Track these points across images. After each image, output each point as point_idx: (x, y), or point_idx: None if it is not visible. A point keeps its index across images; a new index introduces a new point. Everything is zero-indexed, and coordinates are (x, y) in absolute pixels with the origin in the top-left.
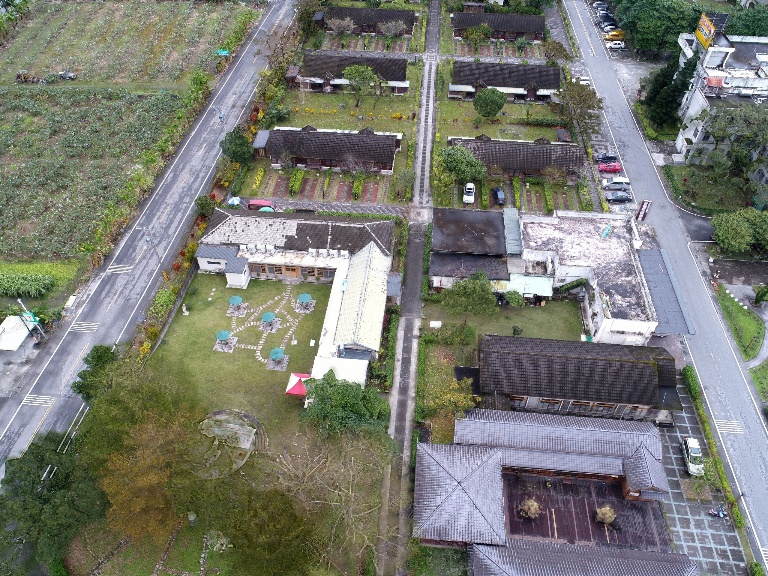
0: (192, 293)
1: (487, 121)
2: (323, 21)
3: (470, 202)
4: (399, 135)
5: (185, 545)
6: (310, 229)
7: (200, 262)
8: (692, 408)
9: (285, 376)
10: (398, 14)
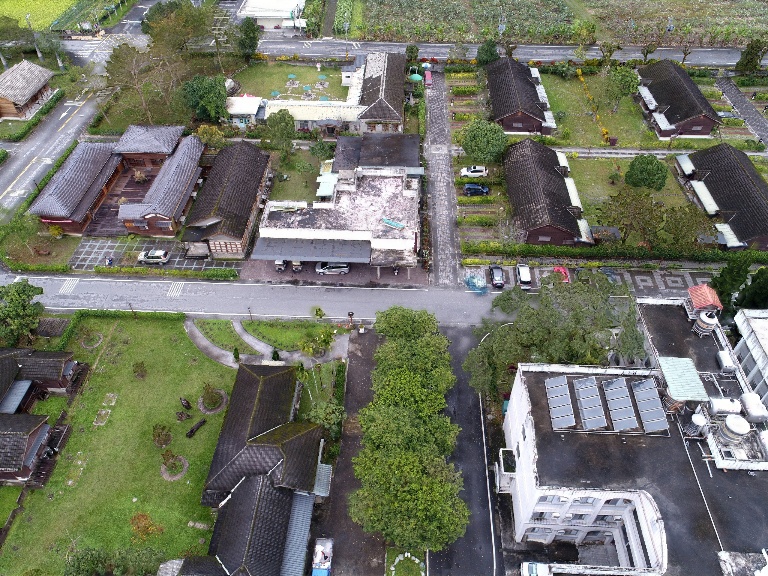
0: (337, 69)
1: None
2: None
3: None
4: (550, 124)
5: None
6: None
7: None
8: None
9: None
10: None
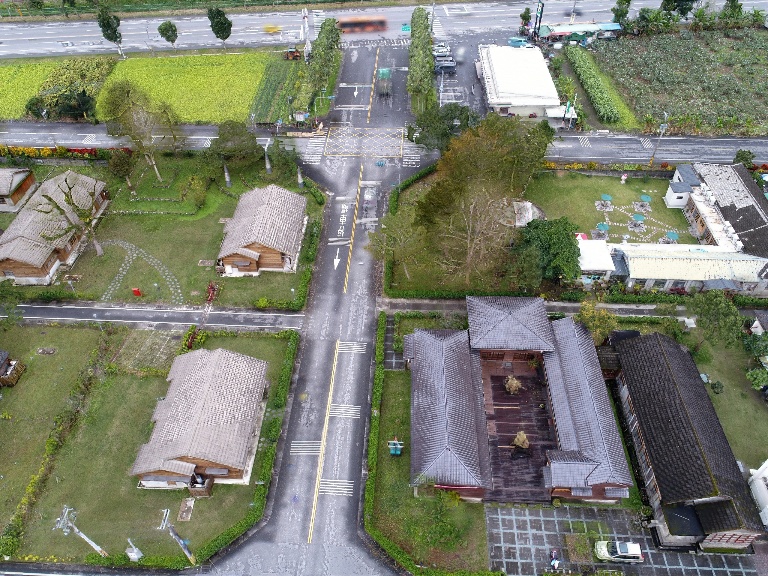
0: (645, 181)
1: None
2: None
3: None
4: None
5: None
6: (752, 214)
7: (676, 173)
8: None
9: None
10: None
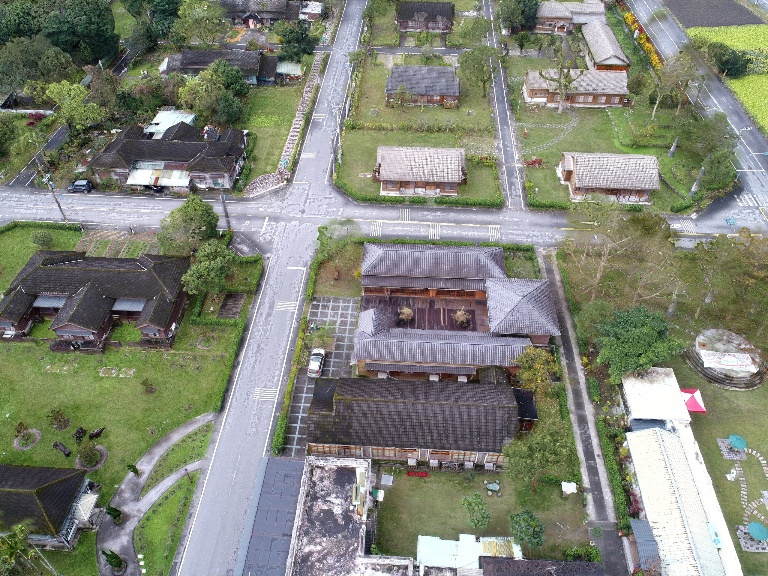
0: None
1: None
2: None
3: None
4: None
5: (701, 296)
6: None
7: None
8: (292, 411)
9: (713, 432)
10: None
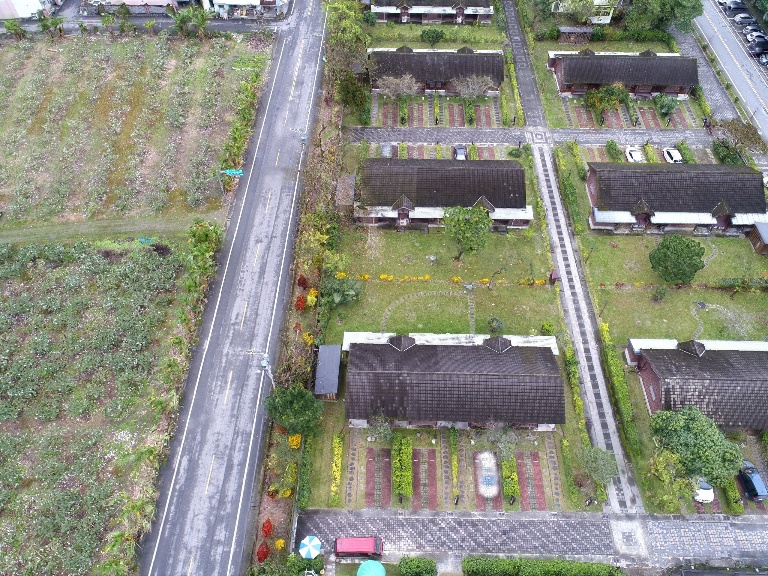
0: None
1: (668, 283)
2: (365, 72)
3: (708, 502)
4: (552, 343)
5: None
6: None
7: None
8: None
9: None
10: (479, 62)
